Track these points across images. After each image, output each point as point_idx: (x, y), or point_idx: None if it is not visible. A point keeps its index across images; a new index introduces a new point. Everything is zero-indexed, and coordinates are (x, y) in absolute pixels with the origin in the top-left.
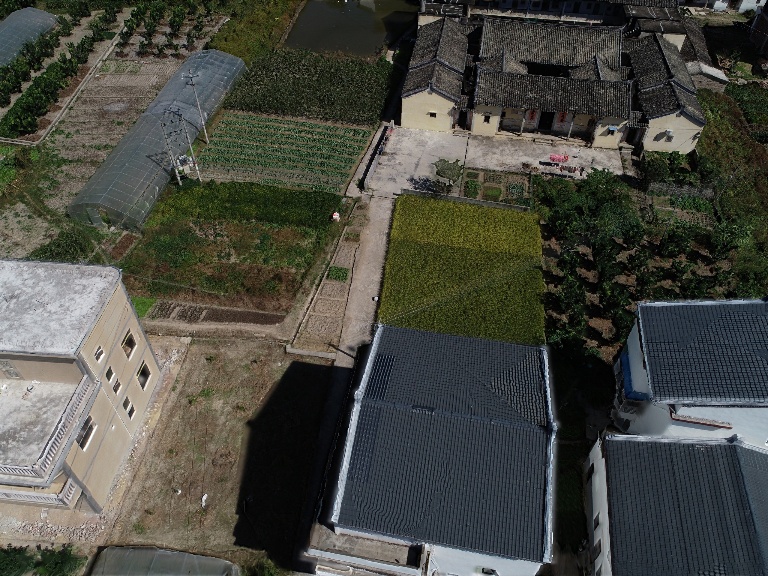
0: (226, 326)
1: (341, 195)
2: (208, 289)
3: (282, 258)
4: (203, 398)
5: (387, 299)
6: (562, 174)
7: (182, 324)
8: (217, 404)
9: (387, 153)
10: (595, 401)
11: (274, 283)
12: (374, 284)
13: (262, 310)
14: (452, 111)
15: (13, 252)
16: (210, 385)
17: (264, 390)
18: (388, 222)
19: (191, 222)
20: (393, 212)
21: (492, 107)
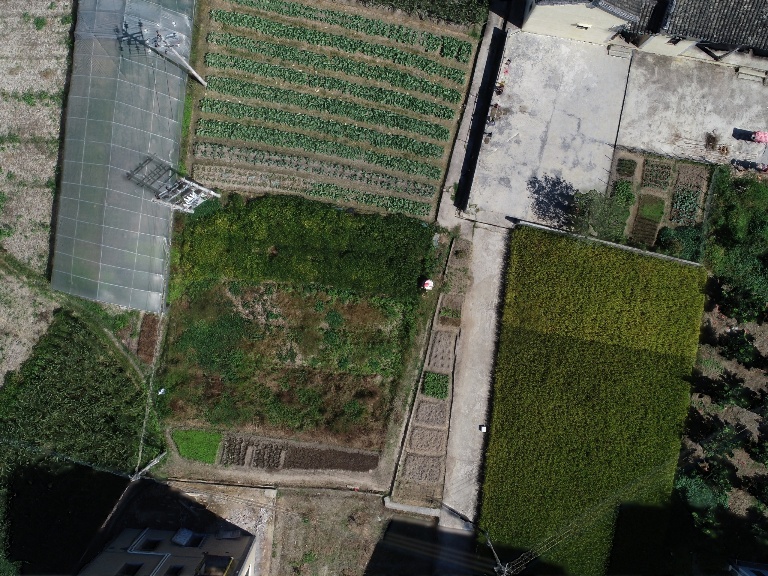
0: (313, 477)
1: (430, 220)
2: (279, 419)
3: (362, 361)
4: (306, 564)
5: (498, 437)
6: (762, 163)
7: (262, 474)
8: (322, 571)
9: (497, 110)
10: (708, 572)
11: (358, 404)
12: (481, 403)
13: (349, 447)
14: (619, 27)
15: (8, 349)
16: (310, 548)
17: (368, 554)
18: (498, 283)
19: (227, 288)
20: (505, 260)
21: (692, 37)
